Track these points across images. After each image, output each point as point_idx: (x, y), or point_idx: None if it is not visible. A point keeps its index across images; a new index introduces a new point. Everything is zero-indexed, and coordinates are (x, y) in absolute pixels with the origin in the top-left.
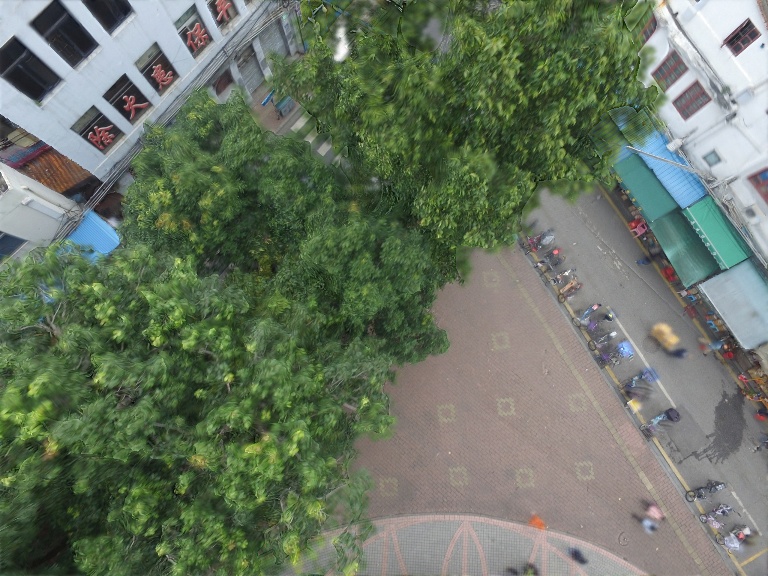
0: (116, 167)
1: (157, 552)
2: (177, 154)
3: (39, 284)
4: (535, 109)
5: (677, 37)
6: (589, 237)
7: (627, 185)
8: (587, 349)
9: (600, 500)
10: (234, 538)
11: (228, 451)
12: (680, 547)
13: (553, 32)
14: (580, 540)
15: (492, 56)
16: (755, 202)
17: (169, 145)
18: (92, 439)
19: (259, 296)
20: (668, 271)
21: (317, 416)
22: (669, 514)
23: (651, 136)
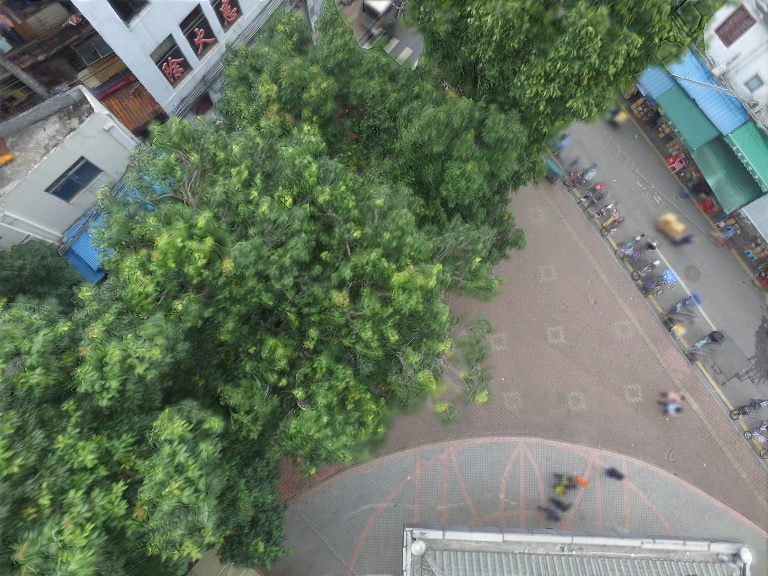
0: (183, 103)
1: (296, 394)
2: (275, 57)
3: (184, 147)
4: None
5: None
6: (629, 174)
7: (669, 116)
8: (631, 279)
9: (649, 420)
10: (359, 390)
11: (365, 294)
12: (727, 463)
13: None
14: (631, 458)
15: None
16: None
17: (258, 57)
18: (252, 271)
19: None
20: (706, 203)
21: None
22: (715, 432)
23: (692, 68)
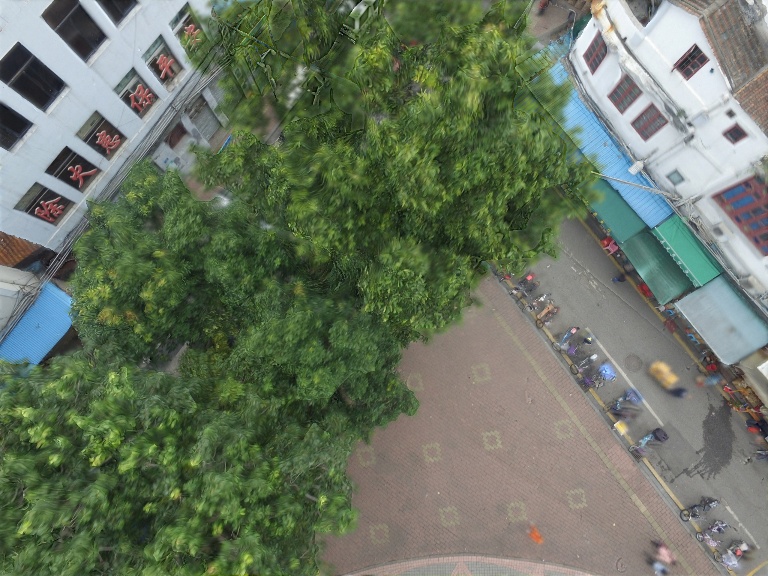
0: (70, 236)
1: None
2: (116, 241)
3: None
4: (461, 205)
5: (628, 62)
6: (562, 258)
7: (594, 207)
8: (569, 373)
9: (594, 527)
10: None
11: (178, 575)
12: (679, 568)
13: (466, 136)
14: (577, 571)
15: (407, 162)
16: (722, 220)
17: None
18: None
19: (216, 376)
20: (644, 287)
21: (275, 518)
22: (665, 535)
23: (614, 157)
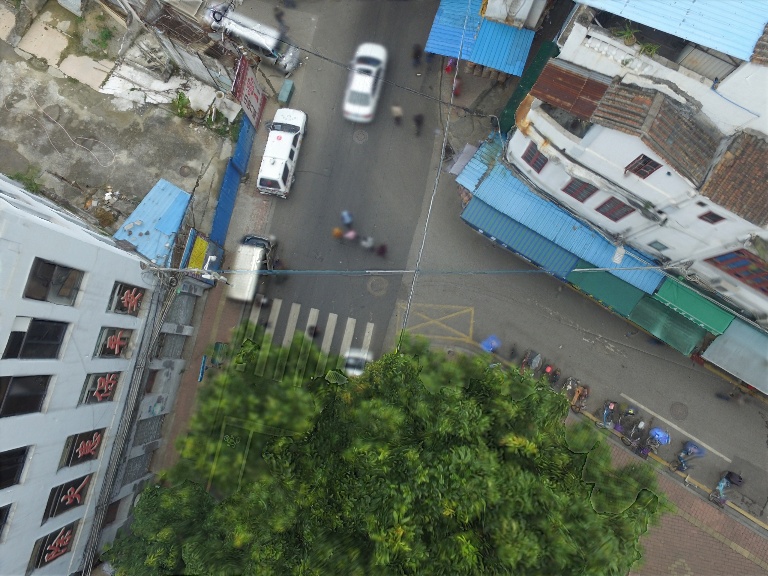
0: (87, 549)
1: None
2: None
3: None
4: None
5: (575, 169)
6: (571, 333)
7: (587, 291)
8: (623, 447)
9: None
10: None
11: None
12: None
13: None
14: None
15: None
16: (720, 276)
17: None
18: None
19: None
20: None
21: None
22: None
23: (587, 237)
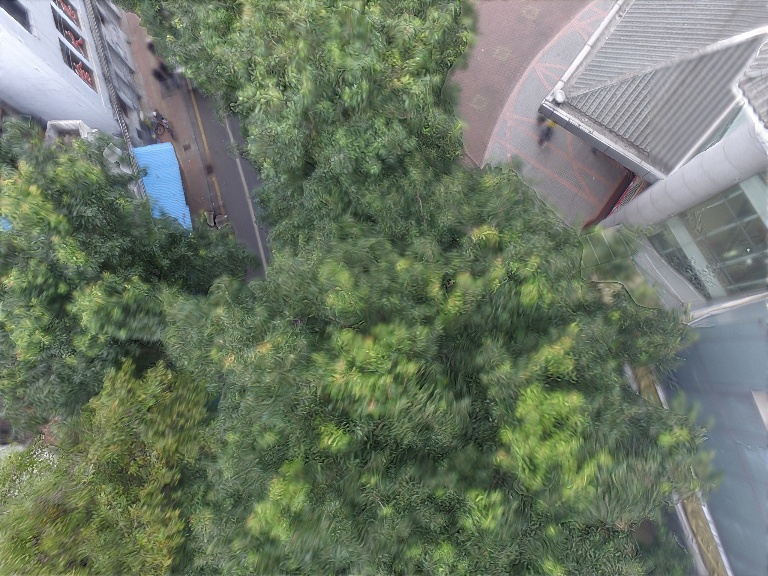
0: (112, 102)
1: None
2: None
3: None
4: None
5: None
6: None
7: None
8: None
9: None
10: None
11: None
12: None
13: None
14: (593, 2)
15: None
16: None
17: None
18: None
19: None
20: None
21: None
22: None
23: None
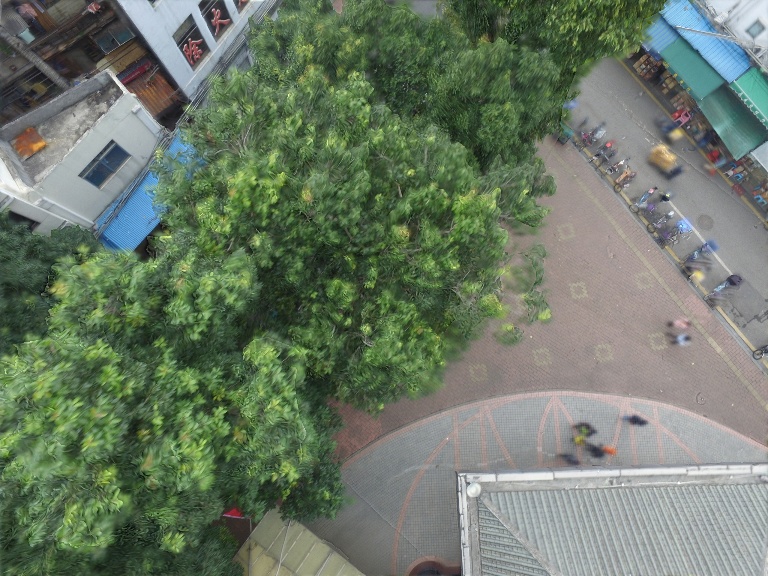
0: (202, 85)
1: (365, 329)
2: (306, 20)
3: (240, 99)
4: None
5: None
6: (636, 131)
7: (674, 69)
8: (647, 232)
9: (675, 366)
10: (420, 325)
11: (425, 226)
12: (753, 401)
13: None
14: (661, 403)
15: None
16: None
17: (285, 25)
18: (322, 206)
19: None
20: (714, 153)
21: None
22: (740, 373)
23: (693, 20)
